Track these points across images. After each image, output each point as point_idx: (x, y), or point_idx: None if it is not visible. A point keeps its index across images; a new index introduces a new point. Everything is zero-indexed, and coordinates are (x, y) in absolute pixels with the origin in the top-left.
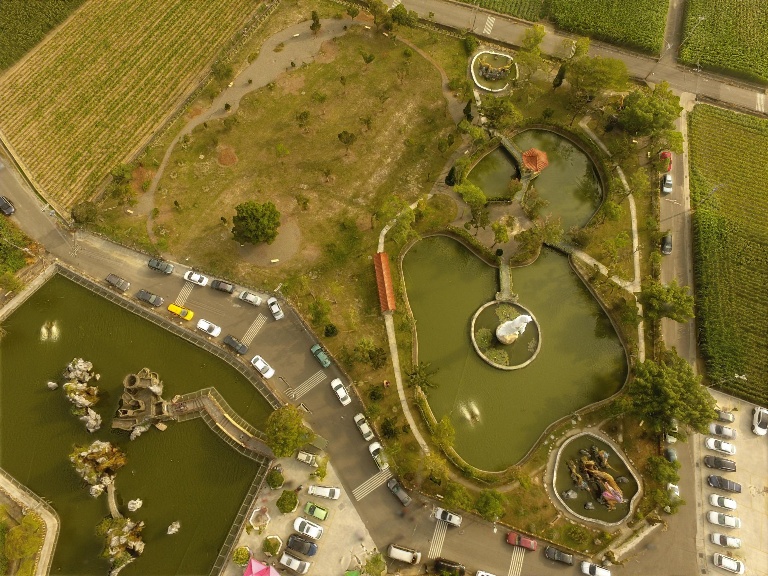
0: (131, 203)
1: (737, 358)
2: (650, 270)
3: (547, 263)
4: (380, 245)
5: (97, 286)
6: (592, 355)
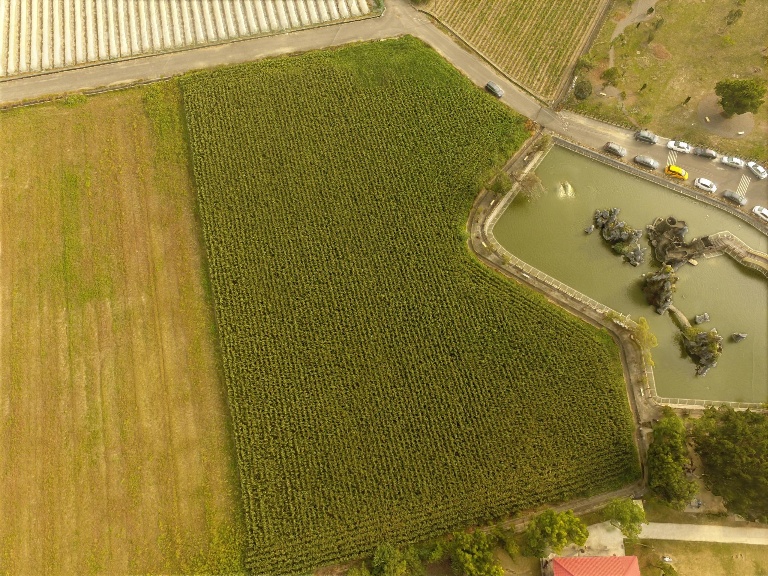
0: (616, 83)
1: None
2: None
3: None
4: None
5: (593, 154)
6: None
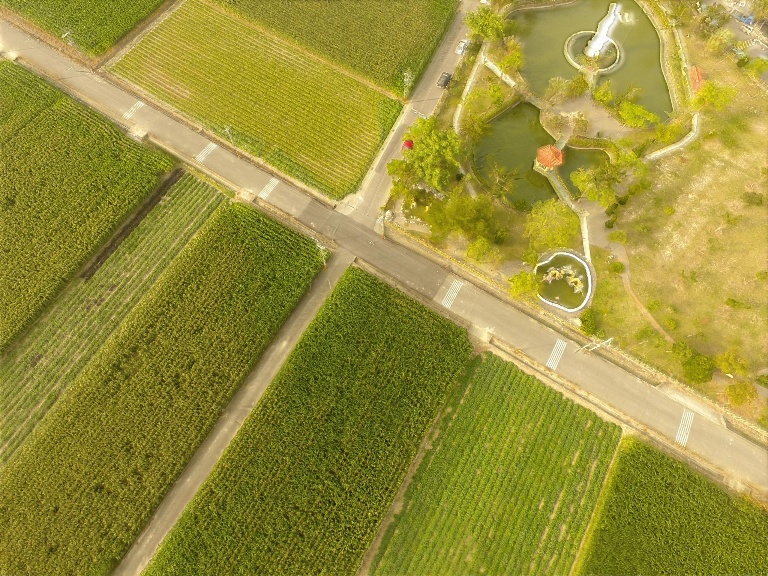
0: None
1: (434, 0)
2: (464, 68)
3: (545, 92)
4: (695, 124)
5: None
6: (525, 34)
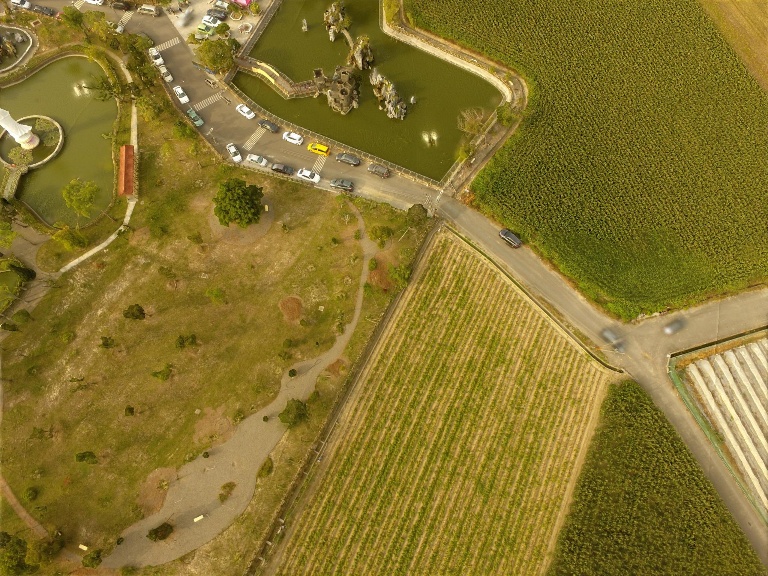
0: None
1: None
2: None
3: None
4: (129, 214)
5: None
6: None
